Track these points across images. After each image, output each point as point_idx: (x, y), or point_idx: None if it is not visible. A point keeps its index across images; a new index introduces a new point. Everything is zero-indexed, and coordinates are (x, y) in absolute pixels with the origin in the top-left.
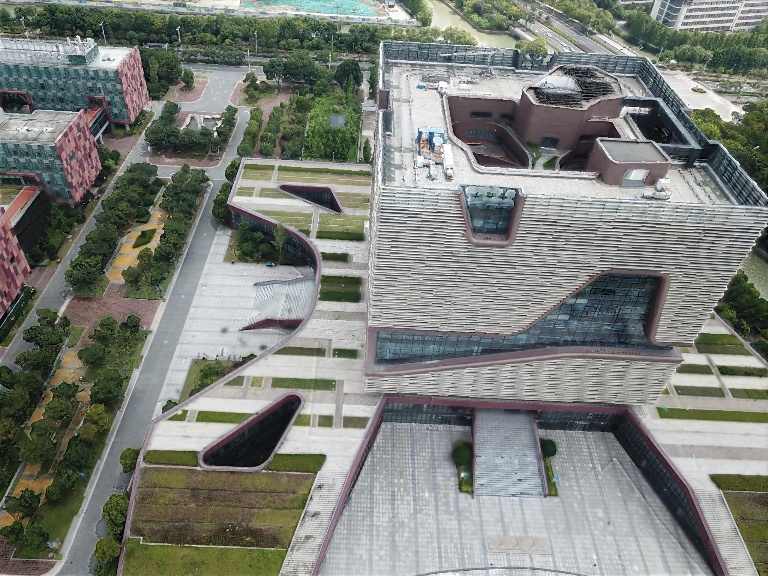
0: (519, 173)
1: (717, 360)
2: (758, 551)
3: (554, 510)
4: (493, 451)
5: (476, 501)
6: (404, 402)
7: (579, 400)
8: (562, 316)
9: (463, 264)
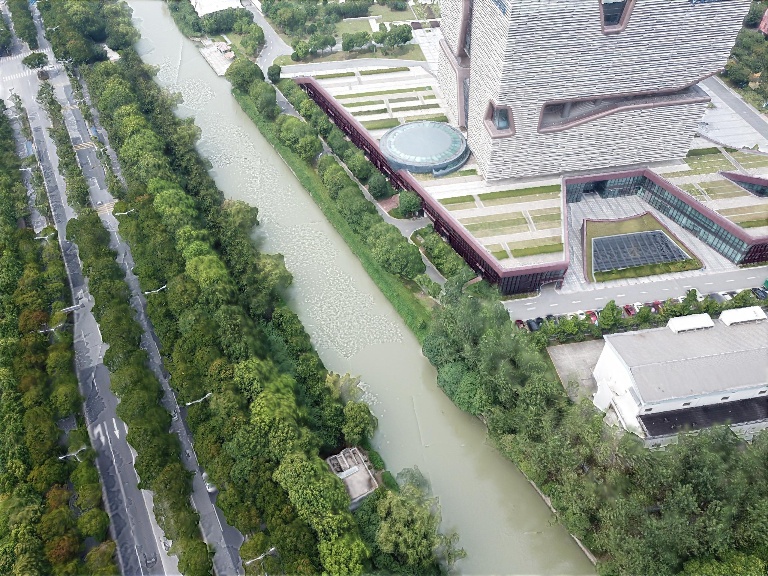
0: None
1: (386, 116)
2: None
3: None
4: None
5: None
6: None
7: None
8: None
9: None
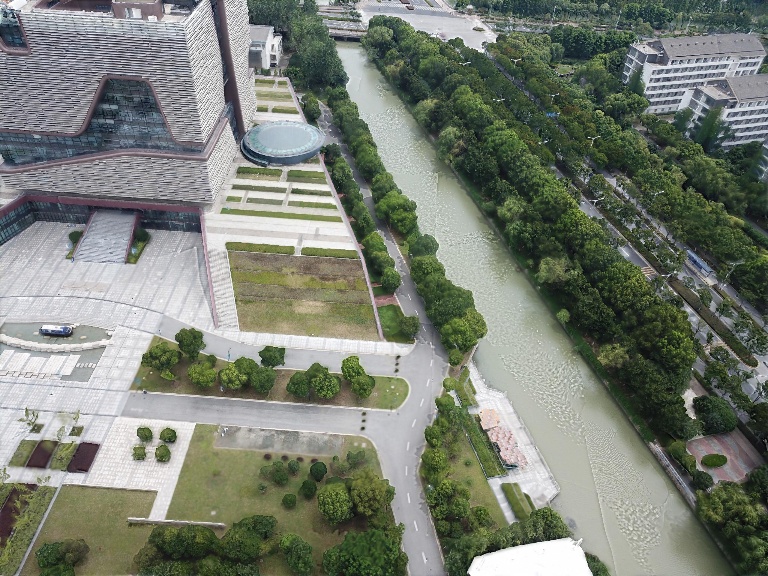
0: (60, 13)
1: (296, 186)
2: (240, 288)
3: (127, 271)
4: (100, 235)
5: (73, 264)
6: (41, 201)
7: (158, 197)
8: (108, 120)
9: (10, 70)
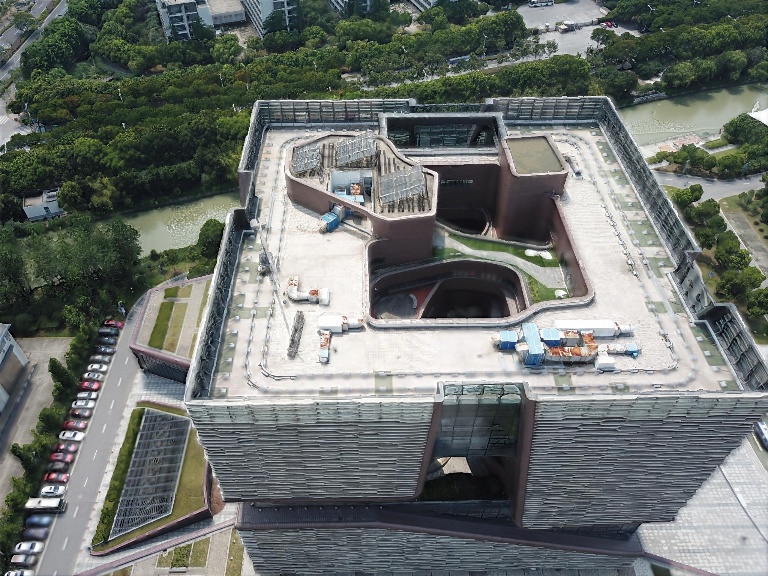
0: None
1: None
2: None
3: None
4: None
5: None
6: None
7: None
8: None
9: None
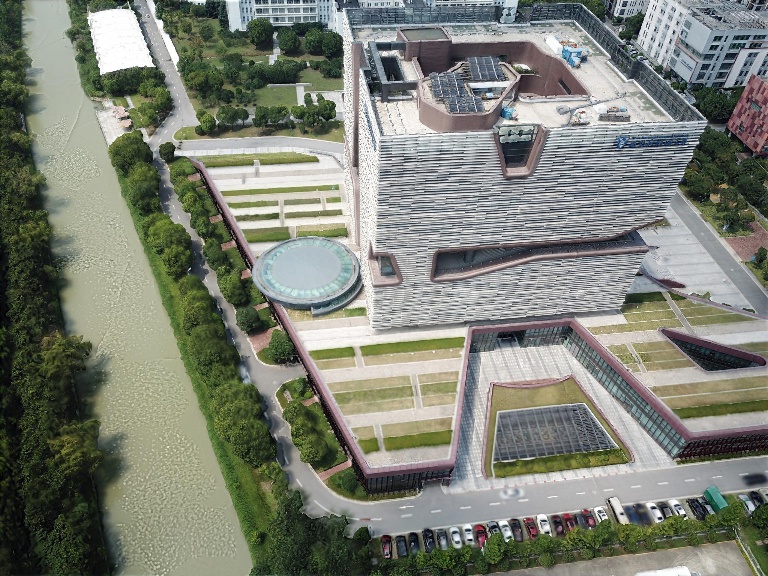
0: None
1: (276, 223)
2: None
3: None
4: None
5: None
6: None
7: None
8: None
9: None
